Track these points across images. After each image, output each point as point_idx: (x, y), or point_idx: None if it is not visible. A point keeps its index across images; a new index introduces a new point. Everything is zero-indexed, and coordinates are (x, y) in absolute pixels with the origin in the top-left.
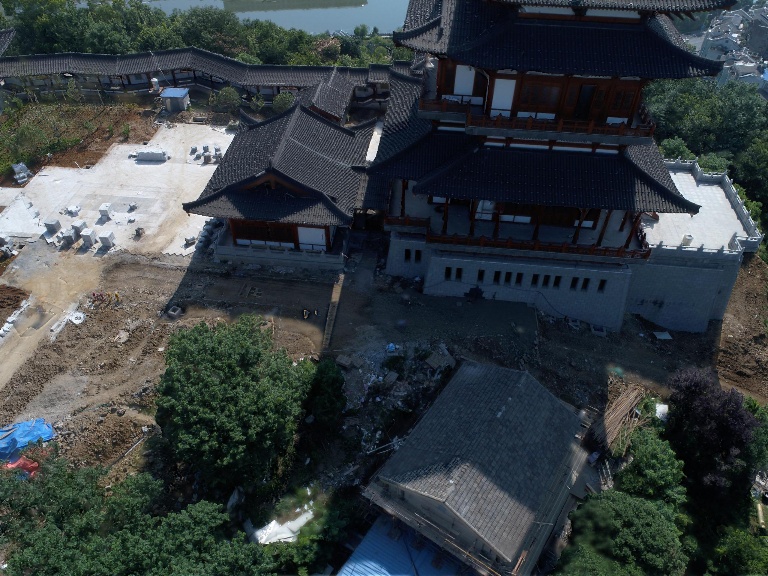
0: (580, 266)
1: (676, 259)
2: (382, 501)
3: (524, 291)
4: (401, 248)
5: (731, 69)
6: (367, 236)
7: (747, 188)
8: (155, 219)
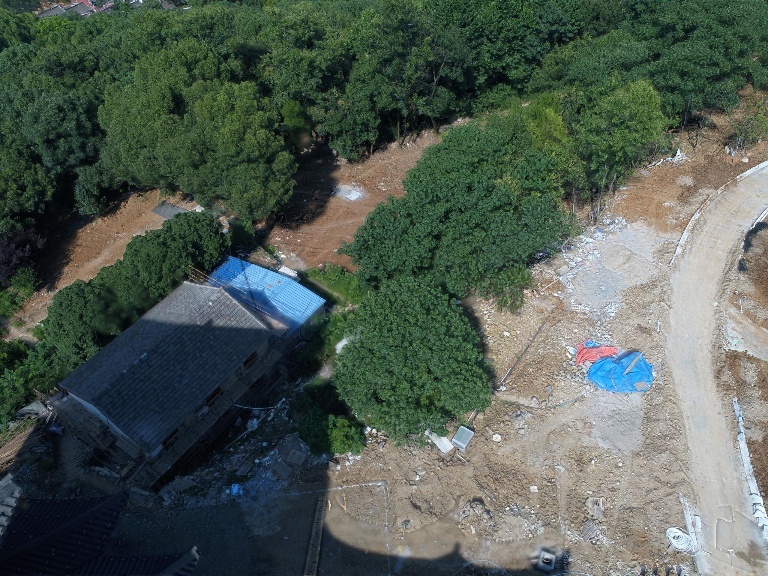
0: None
1: None
2: (273, 323)
3: None
4: None
5: None
6: None
7: None
8: None
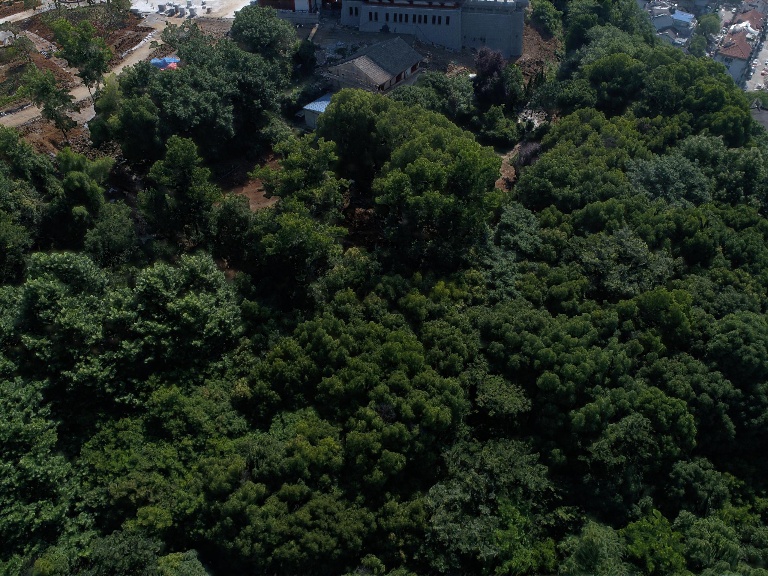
0: (436, 9)
1: (485, 7)
2: None
3: (410, 26)
4: (347, 6)
5: (650, 12)
6: (332, 12)
7: (560, 9)
8: (217, 7)
